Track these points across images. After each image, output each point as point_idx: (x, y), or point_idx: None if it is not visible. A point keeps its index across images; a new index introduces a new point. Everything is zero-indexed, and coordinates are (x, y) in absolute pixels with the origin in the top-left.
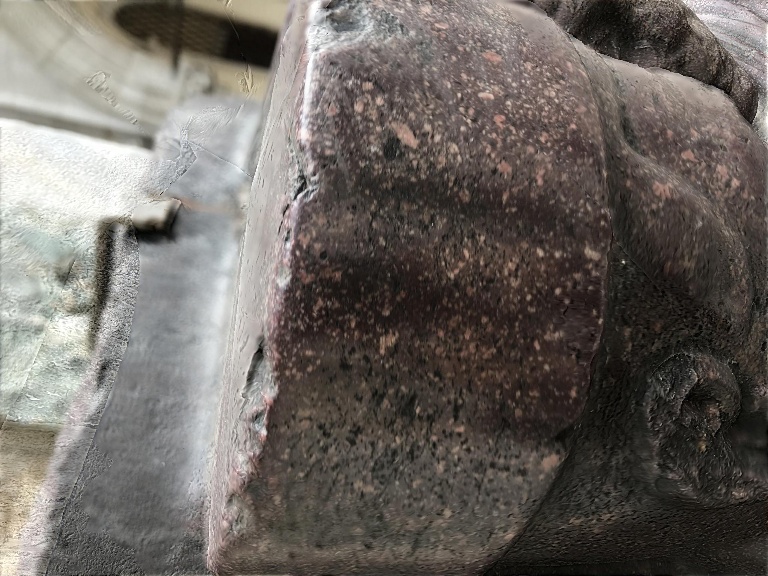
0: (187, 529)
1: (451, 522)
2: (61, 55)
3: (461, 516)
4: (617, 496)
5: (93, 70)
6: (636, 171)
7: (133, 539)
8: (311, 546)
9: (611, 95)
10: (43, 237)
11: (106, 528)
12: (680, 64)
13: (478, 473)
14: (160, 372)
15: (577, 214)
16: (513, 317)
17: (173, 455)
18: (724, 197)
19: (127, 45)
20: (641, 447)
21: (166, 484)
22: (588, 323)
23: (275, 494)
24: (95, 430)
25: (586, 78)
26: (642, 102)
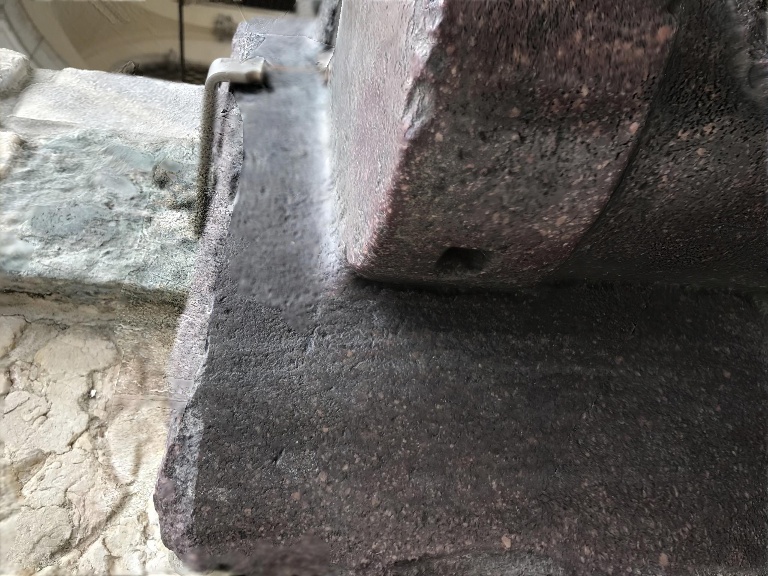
0: (323, 291)
1: (588, 102)
2: (95, 45)
3: (596, 94)
4: (717, 98)
5: (123, 60)
6: None
7: (278, 300)
8: (477, 133)
9: None
10: (126, 149)
11: (253, 295)
12: None
13: (609, 41)
14: (276, 175)
15: None
16: None
17: (300, 235)
18: None
19: (153, 33)
20: (734, 36)
21: (298, 257)
22: None
23: (451, 63)
24: (162, 398)
25: None
26: None
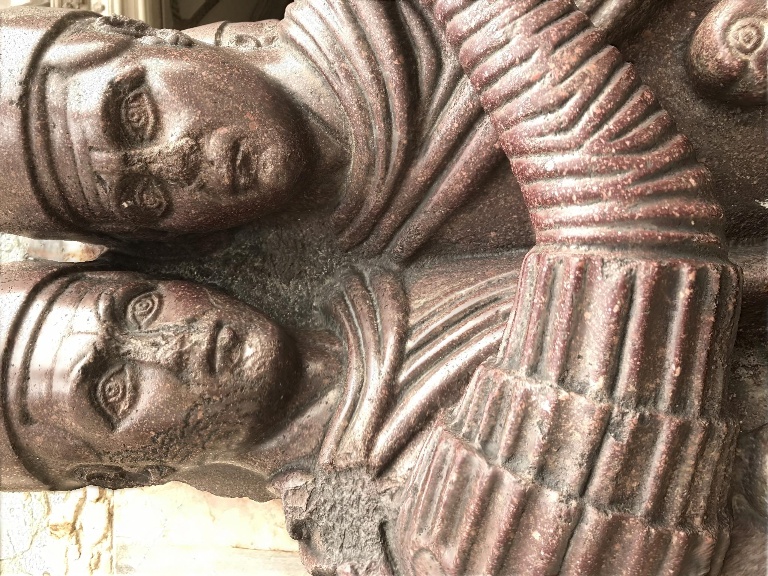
0: None
1: None
2: None
3: None
4: None
5: None
6: (29, 435)
7: None
8: None
9: (17, 406)
10: None
11: None
12: (201, 186)
13: None
14: None
15: (7, 460)
16: (8, 479)
17: None
18: (72, 428)
19: None
20: None
21: None
22: (29, 478)
23: None
24: None
25: (1, 410)
26: (34, 398)
